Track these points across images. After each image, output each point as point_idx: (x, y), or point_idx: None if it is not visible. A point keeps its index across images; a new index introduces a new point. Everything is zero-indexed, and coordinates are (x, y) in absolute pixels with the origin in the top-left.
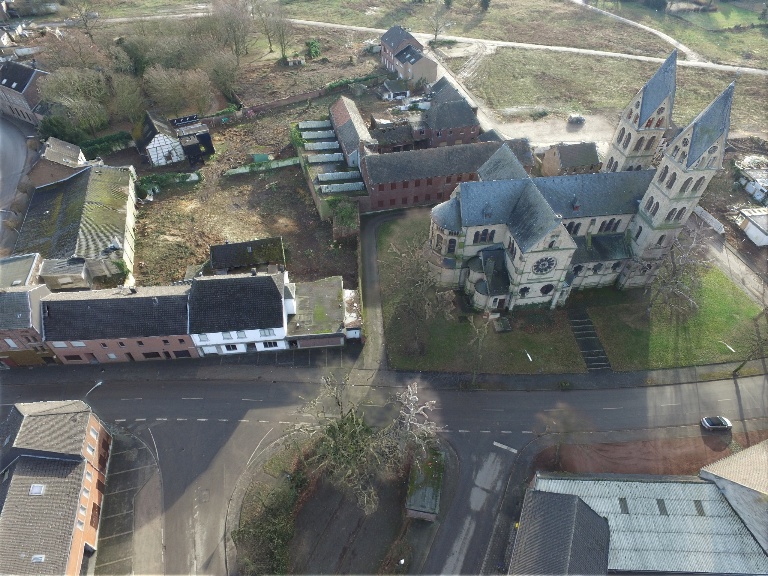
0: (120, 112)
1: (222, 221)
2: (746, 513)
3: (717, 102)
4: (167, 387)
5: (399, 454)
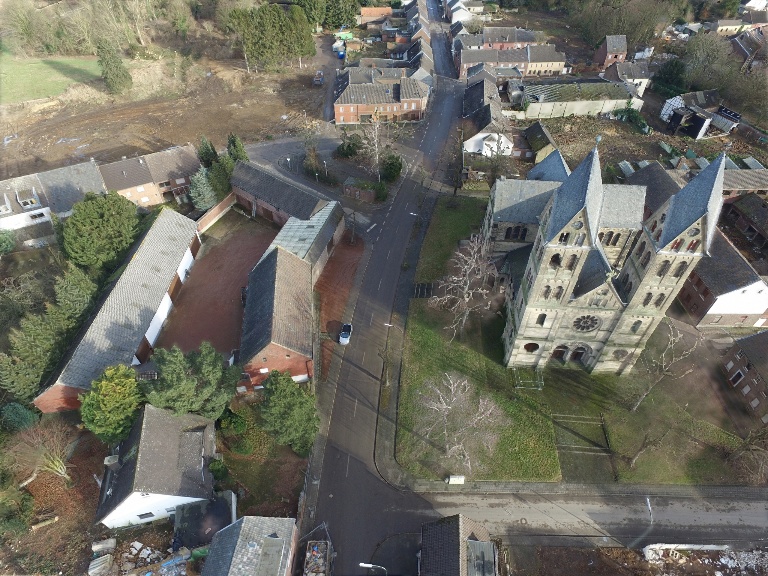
0: (706, 80)
1: (591, 143)
2: None
3: None
4: (444, 132)
5: (365, 153)
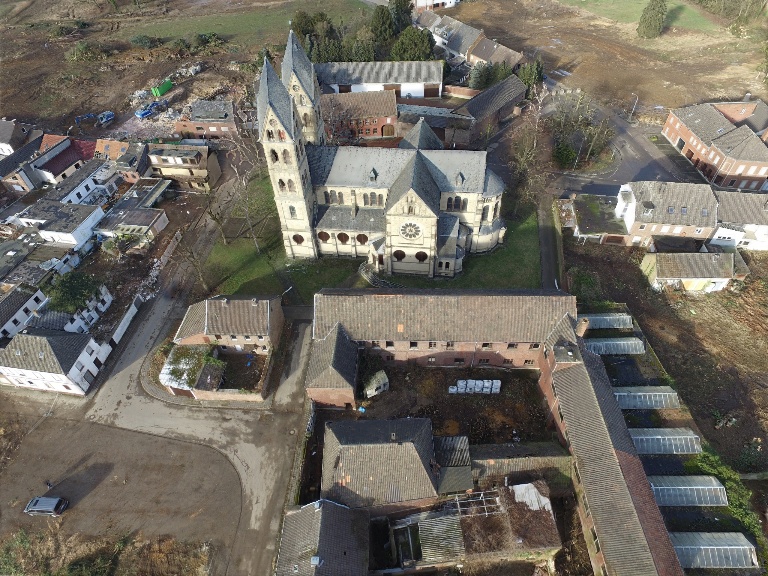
0: None
1: (762, 353)
2: None
3: None
4: None
5: None
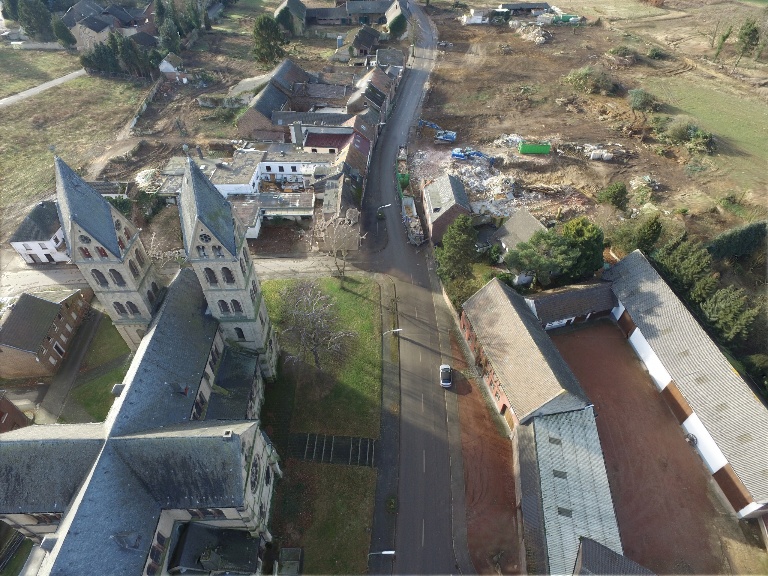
0: None
1: None
2: (560, 408)
3: (195, 185)
4: None
5: None
